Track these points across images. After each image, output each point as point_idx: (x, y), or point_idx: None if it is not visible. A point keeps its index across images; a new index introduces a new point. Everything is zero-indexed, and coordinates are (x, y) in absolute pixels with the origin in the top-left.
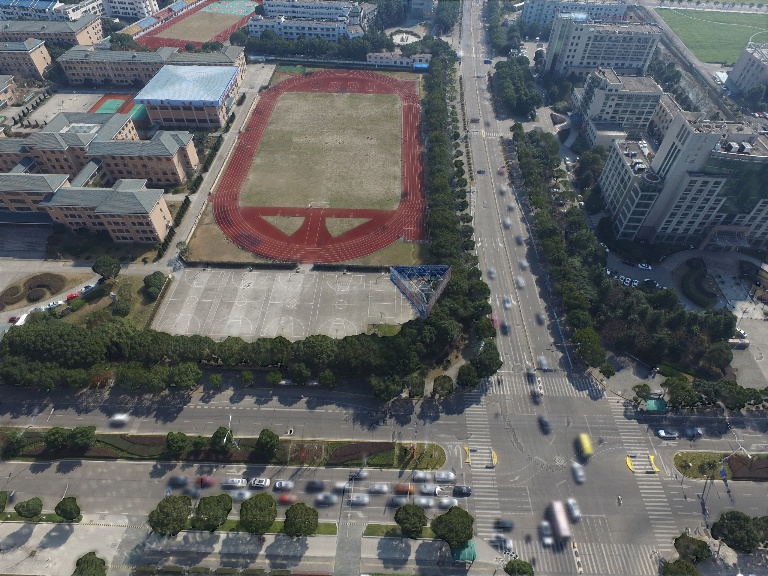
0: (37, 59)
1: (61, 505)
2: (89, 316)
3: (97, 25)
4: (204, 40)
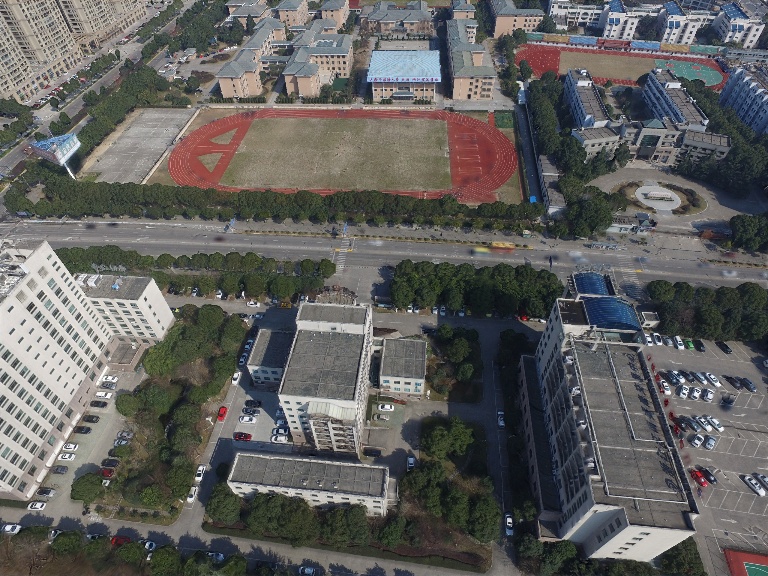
0: (459, 18)
1: (52, 97)
2: (149, 82)
3: (534, 20)
4: (564, 71)
